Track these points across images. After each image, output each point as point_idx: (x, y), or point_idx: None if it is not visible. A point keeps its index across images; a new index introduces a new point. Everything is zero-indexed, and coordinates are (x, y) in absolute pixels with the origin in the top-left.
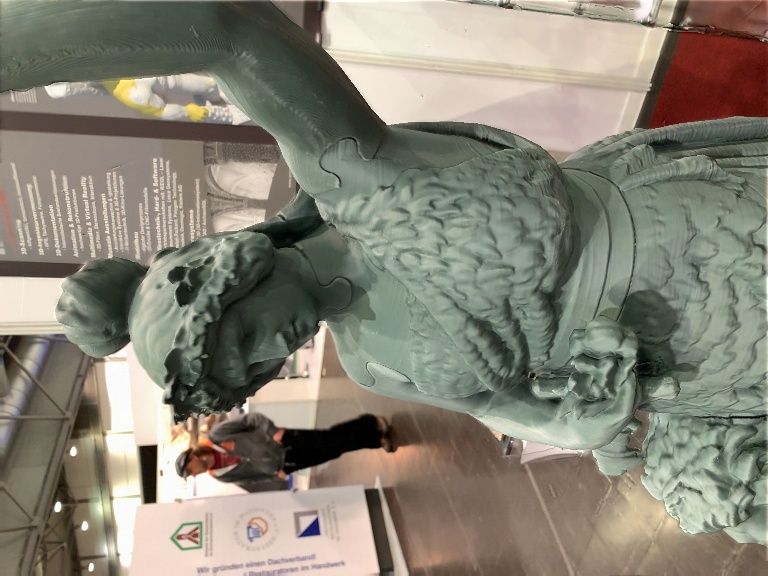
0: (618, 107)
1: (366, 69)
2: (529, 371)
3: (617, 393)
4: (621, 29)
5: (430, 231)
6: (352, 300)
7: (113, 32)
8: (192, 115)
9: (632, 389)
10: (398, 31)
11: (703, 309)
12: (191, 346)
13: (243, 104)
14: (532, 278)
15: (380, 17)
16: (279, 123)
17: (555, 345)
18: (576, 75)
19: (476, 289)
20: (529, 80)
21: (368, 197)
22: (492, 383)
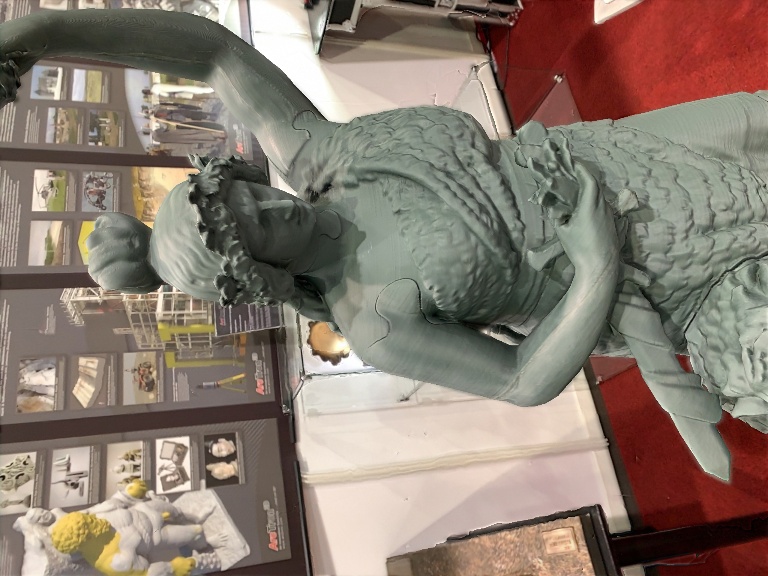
0: (591, 467)
1: (346, 487)
2: (522, 266)
3: (576, 178)
4: (553, 402)
5: (379, 129)
6: (342, 230)
7: (162, 16)
8: (178, 570)
9: (583, 167)
10: (366, 444)
11: (612, 160)
12: (210, 172)
13: (236, 86)
14: (464, 134)
15: (347, 438)
16: (261, 95)
17: (521, 211)
18: (538, 447)
19: (426, 144)
20: (499, 461)
21: (331, 137)
22: (479, 223)
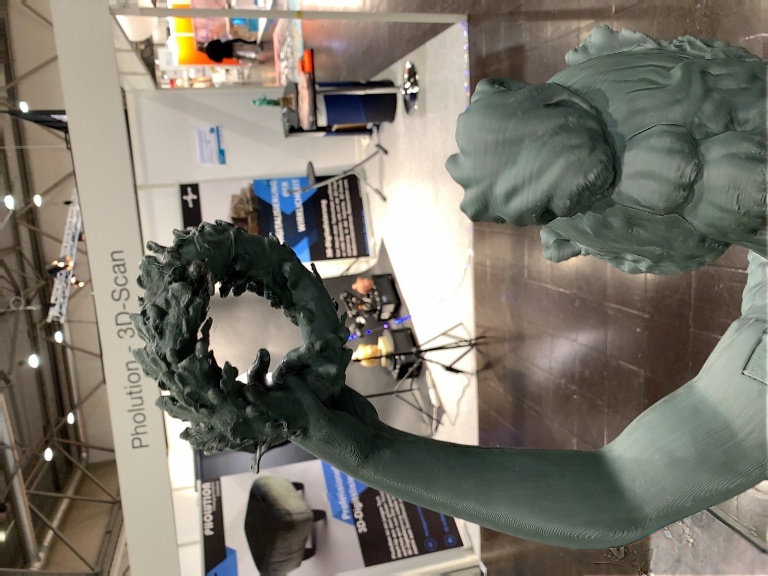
0: None
1: None
2: None
3: None
4: None
5: None
6: None
7: None
8: None
9: None
10: None
11: None
12: None
13: None
14: None
15: None
16: None
17: None
18: None
19: None
20: None
21: None
22: None
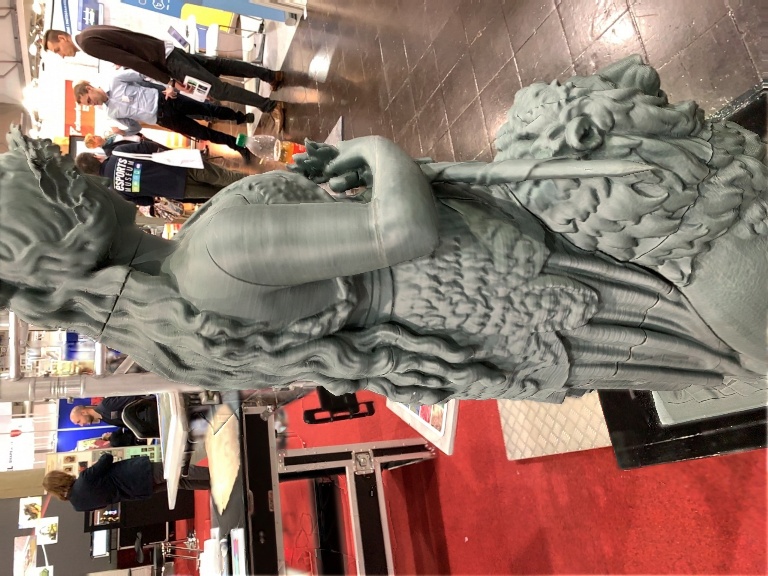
0: None
1: None
2: None
3: None
4: None
5: None
6: None
7: None
8: None
9: None
10: None
11: None
12: None
13: None
14: None
15: None
16: None
17: None
18: None
19: None
20: None
21: None
22: None
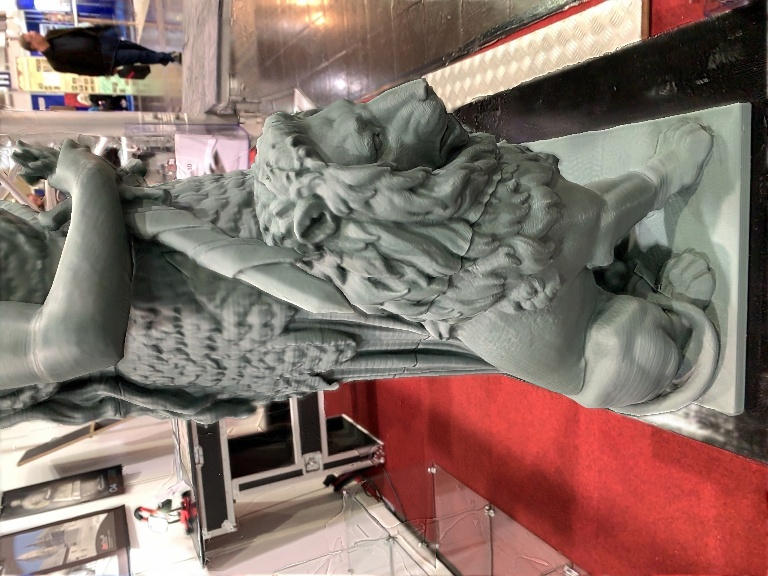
0: None
1: None
2: (49, 243)
3: None
4: None
5: None
6: None
7: None
8: None
9: None
10: None
11: None
12: None
13: None
14: None
15: None
16: None
17: None
18: None
19: None
20: None
21: None
22: None
